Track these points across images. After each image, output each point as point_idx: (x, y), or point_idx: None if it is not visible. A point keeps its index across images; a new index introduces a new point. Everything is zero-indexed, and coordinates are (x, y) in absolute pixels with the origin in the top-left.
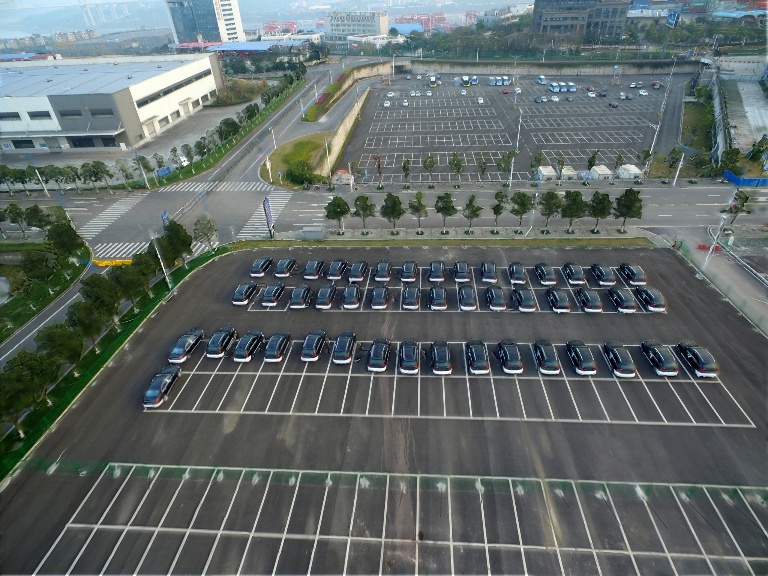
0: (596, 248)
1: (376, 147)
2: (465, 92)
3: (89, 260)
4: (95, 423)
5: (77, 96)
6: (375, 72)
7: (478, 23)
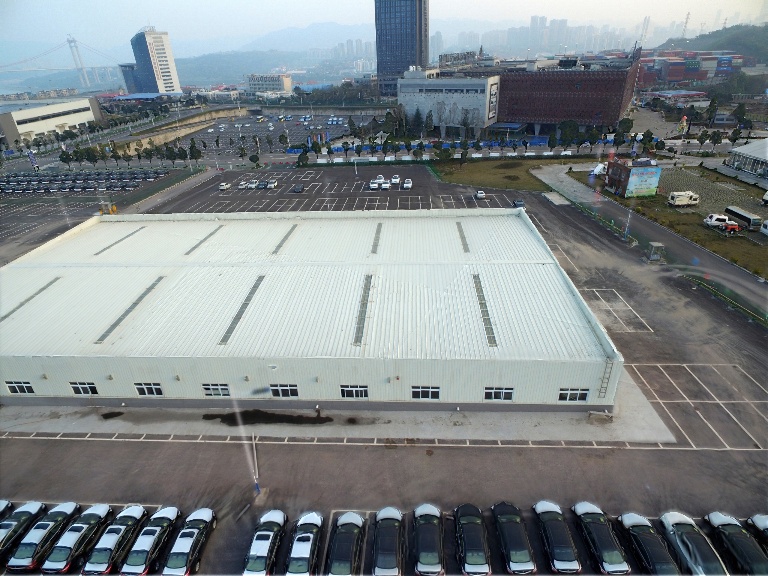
0: (171, 170)
1: None
2: (271, 124)
3: None
4: None
5: None
6: (233, 114)
7: (346, 83)
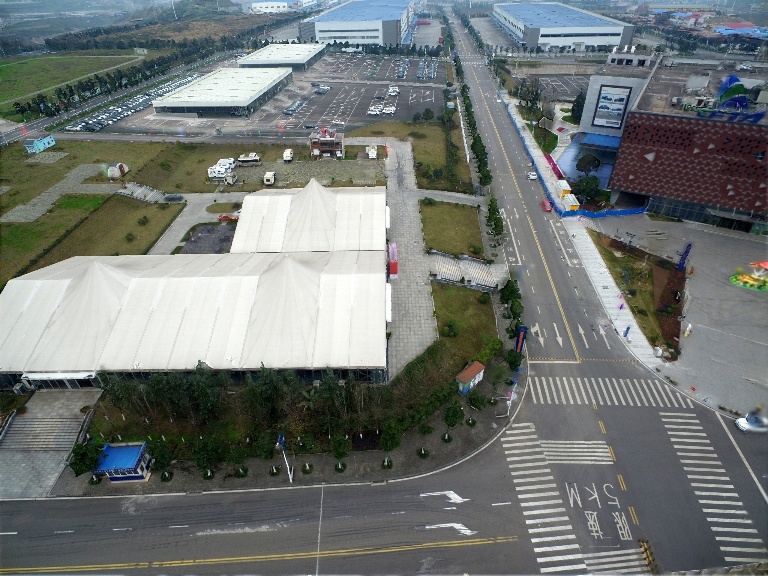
0: None
1: None
2: None
3: (441, 56)
4: None
5: None
6: None
7: None
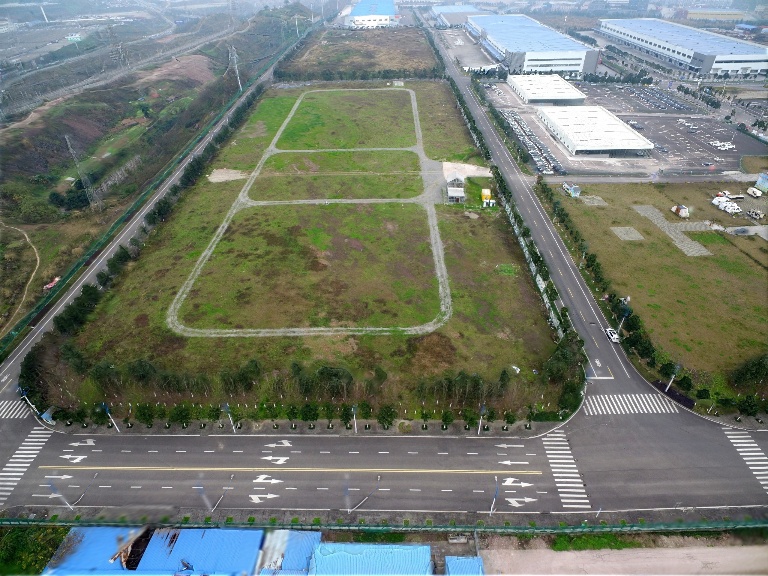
0: None
1: (766, 102)
2: None
3: None
4: (611, 87)
5: (700, 54)
6: None
7: None
